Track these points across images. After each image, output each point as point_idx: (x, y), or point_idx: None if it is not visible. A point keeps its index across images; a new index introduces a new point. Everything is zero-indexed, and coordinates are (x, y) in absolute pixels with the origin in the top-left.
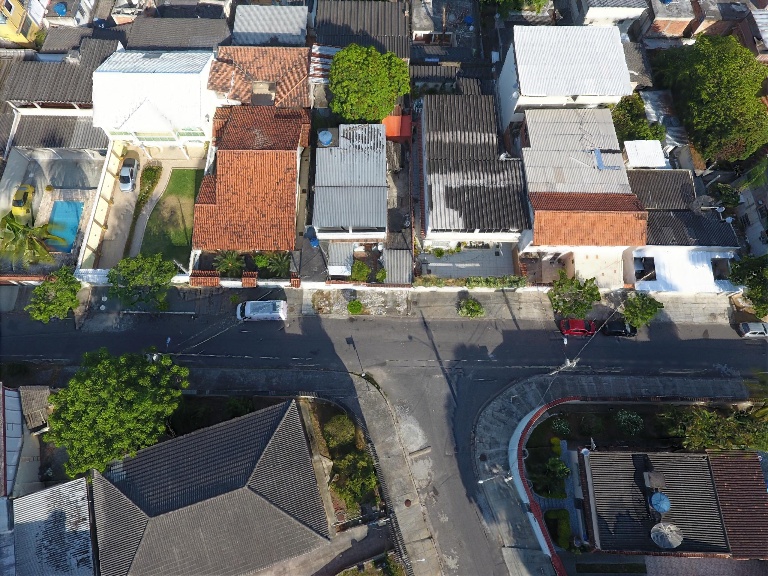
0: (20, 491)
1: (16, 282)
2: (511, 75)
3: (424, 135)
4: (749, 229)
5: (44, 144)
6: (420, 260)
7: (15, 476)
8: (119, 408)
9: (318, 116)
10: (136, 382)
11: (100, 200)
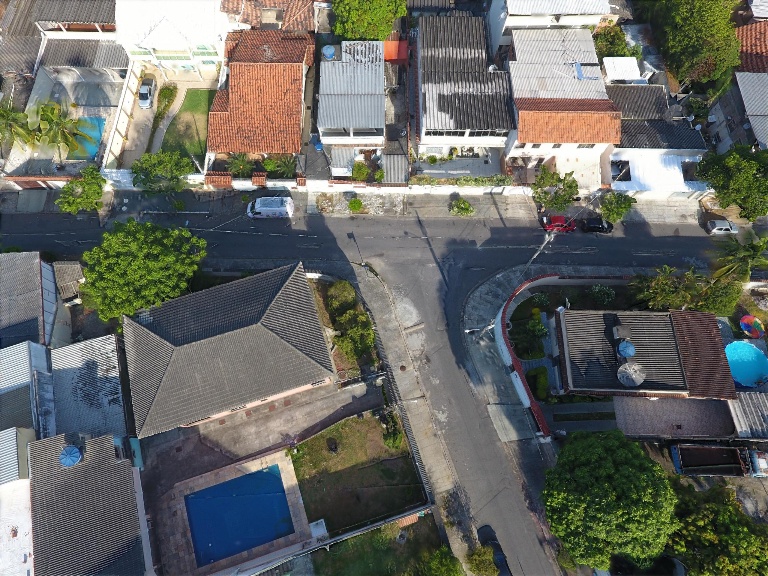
0: (56, 345)
1: (45, 185)
2: (500, 1)
3: (419, 52)
4: (720, 145)
5: (69, 64)
6: (415, 167)
7: (52, 332)
8: (147, 260)
9: (322, 40)
10: (161, 242)
11: (122, 112)
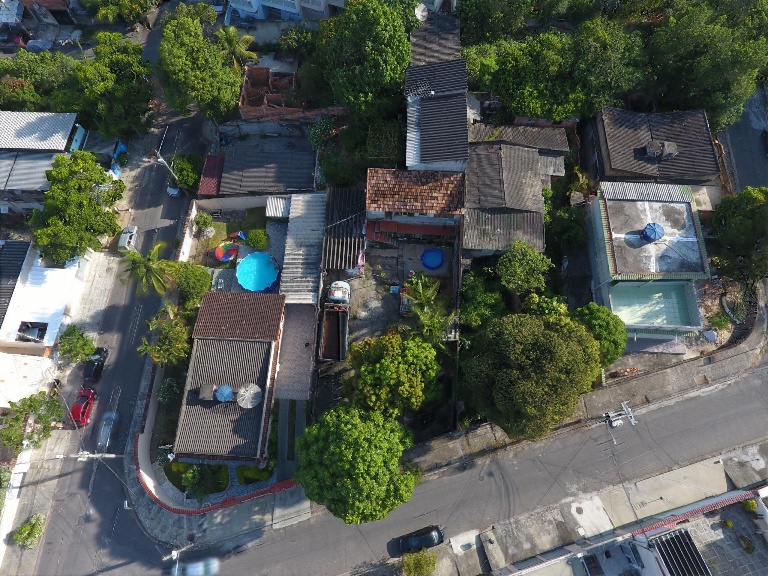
0: None
1: None
2: None
3: None
4: None
5: None
6: None
7: None
8: None
9: None
10: None
11: None
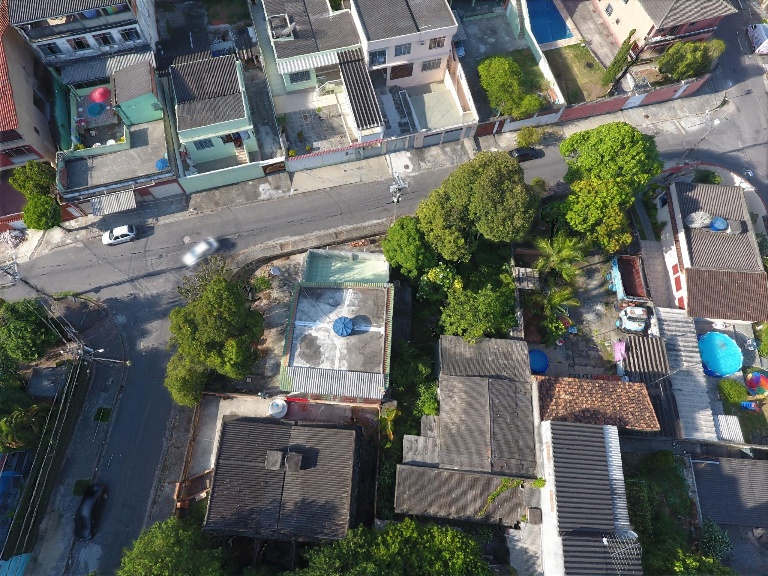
0: None
1: None
2: None
3: None
4: None
5: None
6: None
7: None
8: None
9: None
10: None
11: None
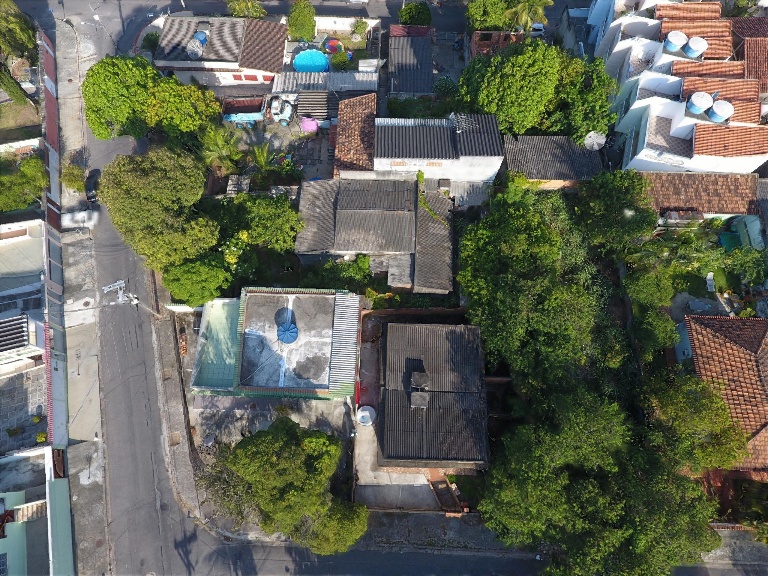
0: None
1: None
2: None
3: None
4: None
5: None
6: None
7: None
8: None
9: None
10: None
11: None
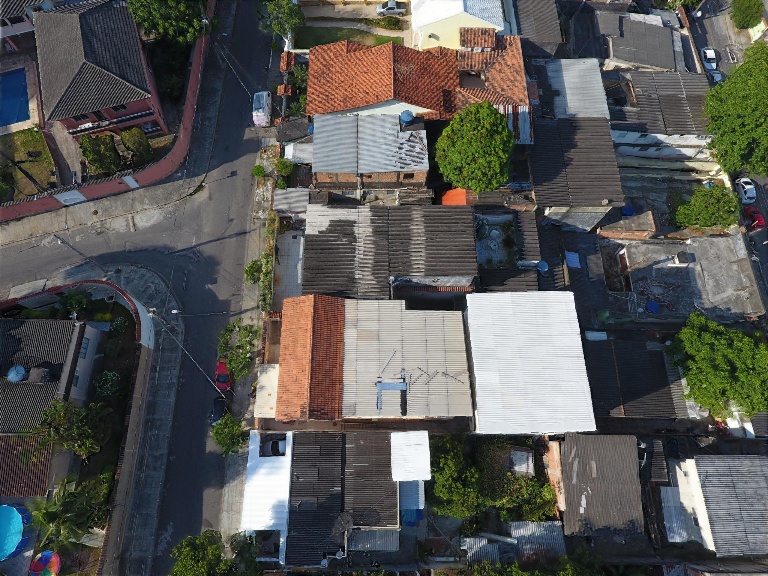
0: None
1: None
2: None
3: None
4: None
5: None
6: None
7: None
8: None
9: None
10: None
11: None
